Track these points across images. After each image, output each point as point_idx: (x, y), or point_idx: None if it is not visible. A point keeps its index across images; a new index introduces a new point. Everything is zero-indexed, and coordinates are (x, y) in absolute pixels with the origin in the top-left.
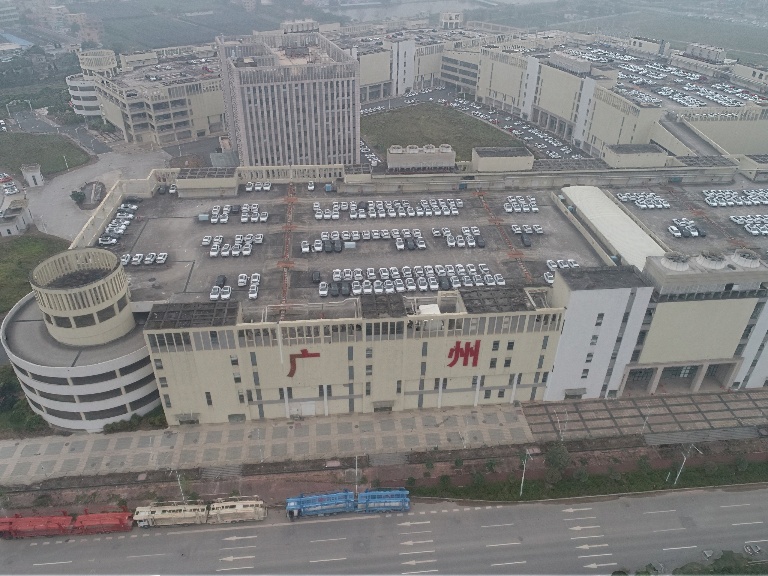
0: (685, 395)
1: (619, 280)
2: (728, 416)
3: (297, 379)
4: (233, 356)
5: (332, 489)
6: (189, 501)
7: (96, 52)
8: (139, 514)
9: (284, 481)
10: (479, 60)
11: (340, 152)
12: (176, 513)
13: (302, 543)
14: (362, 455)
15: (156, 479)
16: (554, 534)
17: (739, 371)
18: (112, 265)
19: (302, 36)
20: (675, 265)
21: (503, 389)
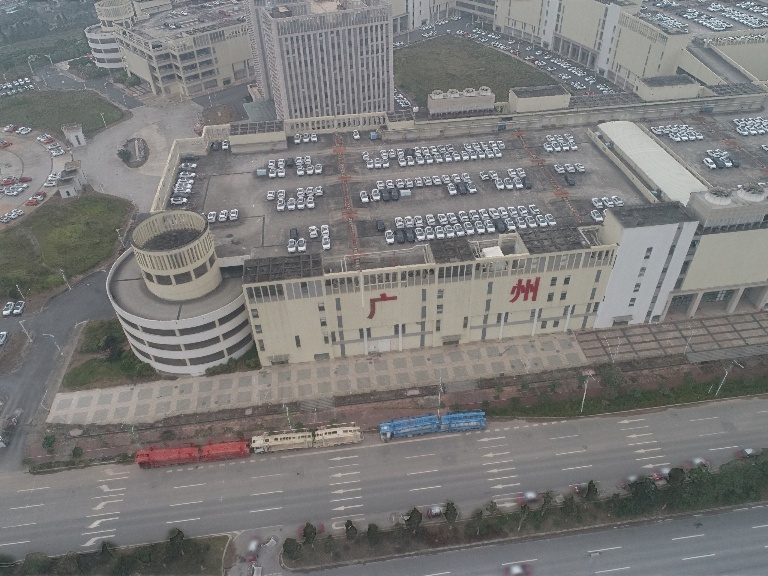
0: (721, 316)
1: (666, 216)
2: (761, 333)
3: (376, 320)
4: (320, 303)
5: (416, 414)
6: (296, 430)
7: (111, 1)
8: (255, 442)
9: (372, 409)
10: None
11: (375, 97)
12: (288, 440)
13: (398, 460)
14: (438, 384)
15: (261, 413)
16: (614, 442)
17: None
18: (197, 225)
19: None
20: (719, 200)
21: (558, 319)
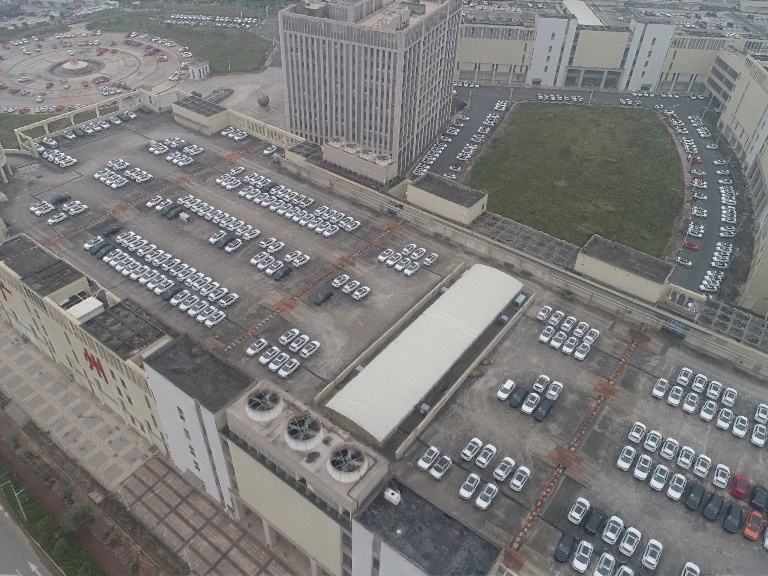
0: None
1: (216, 384)
2: None
3: None
4: None
5: None
6: None
7: None
8: None
9: None
10: None
11: (377, 129)
12: None
13: None
14: (8, 397)
15: None
16: None
17: None
18: None
19: None
20: None
21: None
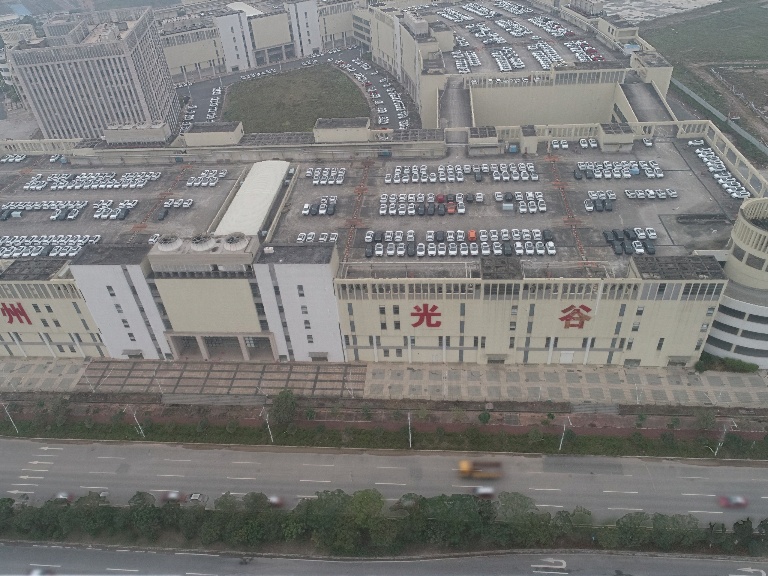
0: (235, 363)
1: (129, 257)
2: (252, 385)
3: None
4: None
5: None
6: None
7: (20, 26)
8: None
9: None
10: (369, 19)
11: None
12: None
13: None
14: None
15: None
16: (13, 465)
17: (277, 345)
18: None
19: (136, 10)
20: (161, 246)
21: (72, 345)
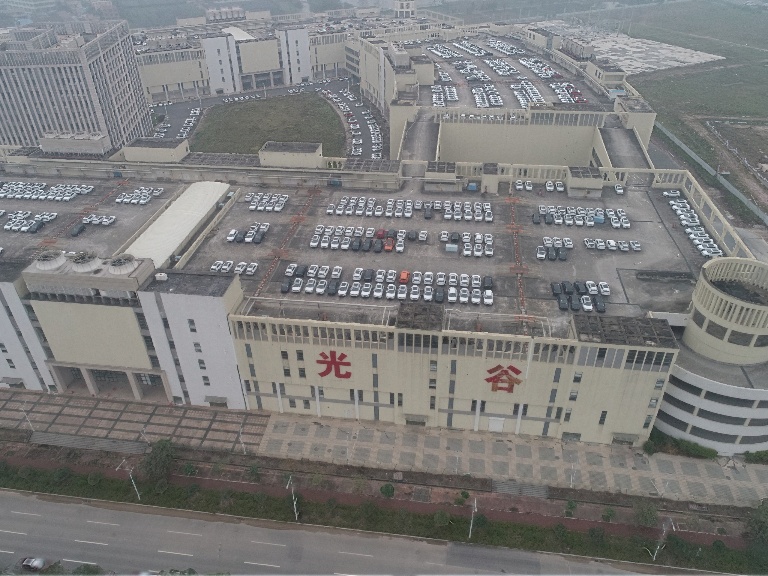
0: (125, 401)
1: (7, 273)
2: (136, 429)
3: None
4: None
5: None
6: None
7: (7, 36)
8: None
9: None
10: None
11: None
12: None
13: None
14: None
15: None
16: None
17: (170, 385)
18: None
19: (111, 23)
20: (38, 263)
21: None
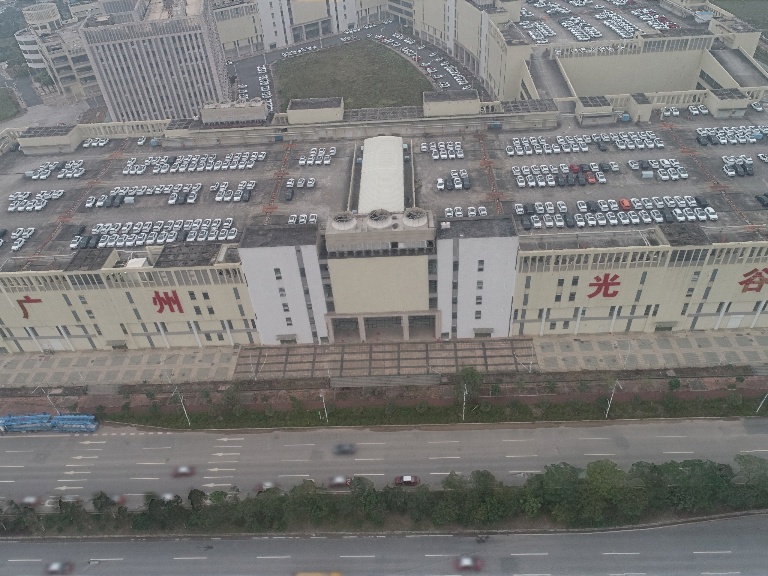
0: (395, 343)
1: (296, 238)
2: (421, 364)
3: (33, 320)
4: None
5: None
6: None
7: (42, 5)
8: None
9: (14, 403)
10: None
11: None
12: None
13: None
14: (83, 385)
15: None
16: (197, 458)
17: (442, 322)
18: None
19: None
20: (337, 224)
21: (220, 333)
